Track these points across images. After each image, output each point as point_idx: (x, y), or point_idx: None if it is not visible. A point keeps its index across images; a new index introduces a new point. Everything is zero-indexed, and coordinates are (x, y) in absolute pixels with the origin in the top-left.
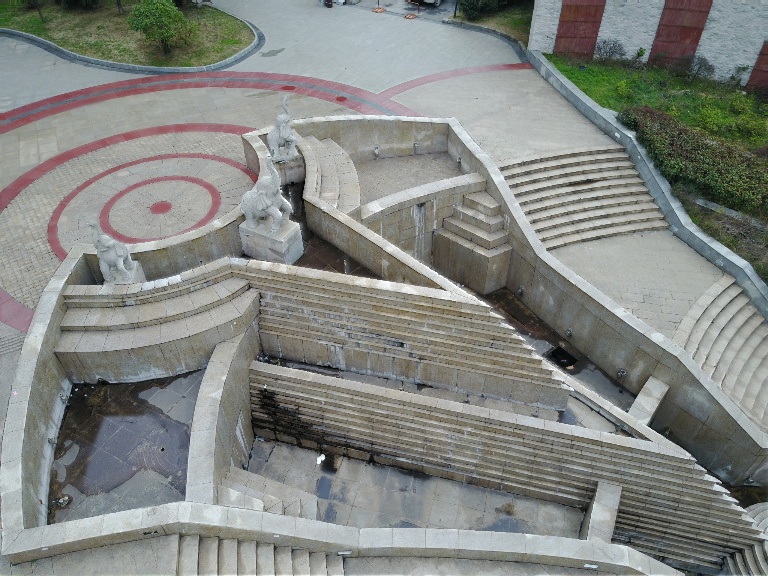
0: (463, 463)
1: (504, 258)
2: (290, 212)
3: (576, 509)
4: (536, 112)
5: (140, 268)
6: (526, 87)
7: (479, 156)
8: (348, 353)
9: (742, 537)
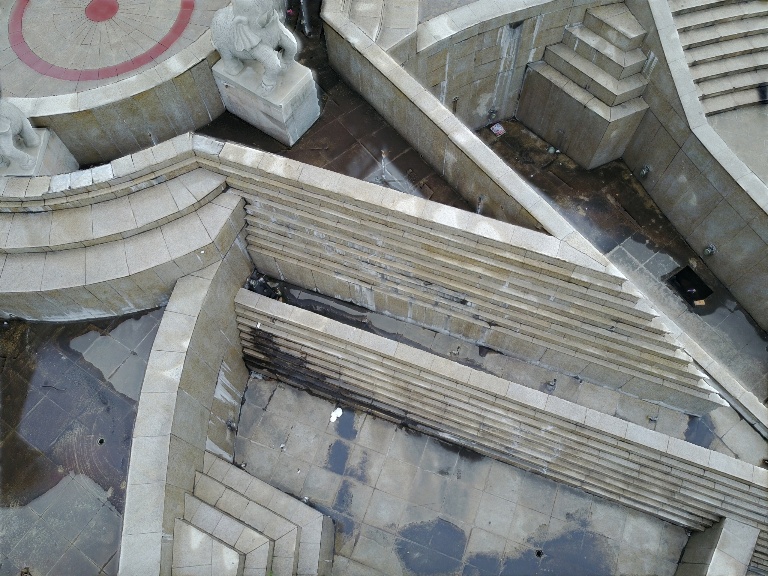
0: (531, 456)
1: (632, 121)
2: (295, 52)
3: (678, 528)
4: None
5: (54, 139)
6: None
7: None
8: (380, 296)
9: None
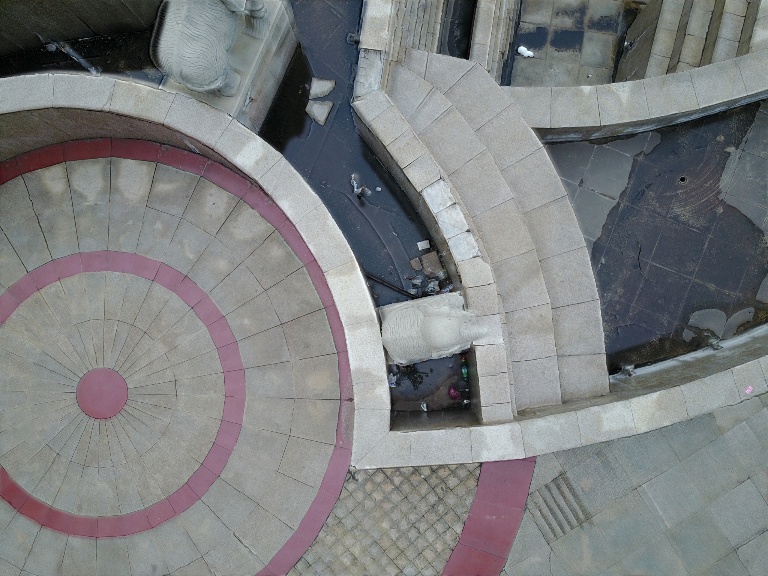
0: None
1: None
2: None
3: None
4: None
5: None
6: None
7: None
8: None
9: None
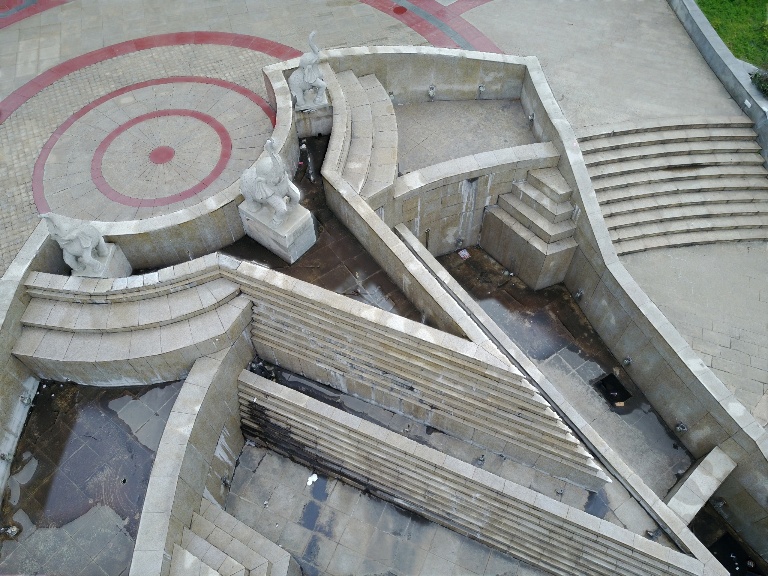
0: (467, 521)
1: (565, 255)
2: (298, 200)
3: None
4: (645, 54)
5: (118, 251)
6: (640, 12)
7: (556, 122)
8: (350, 381)
9: None
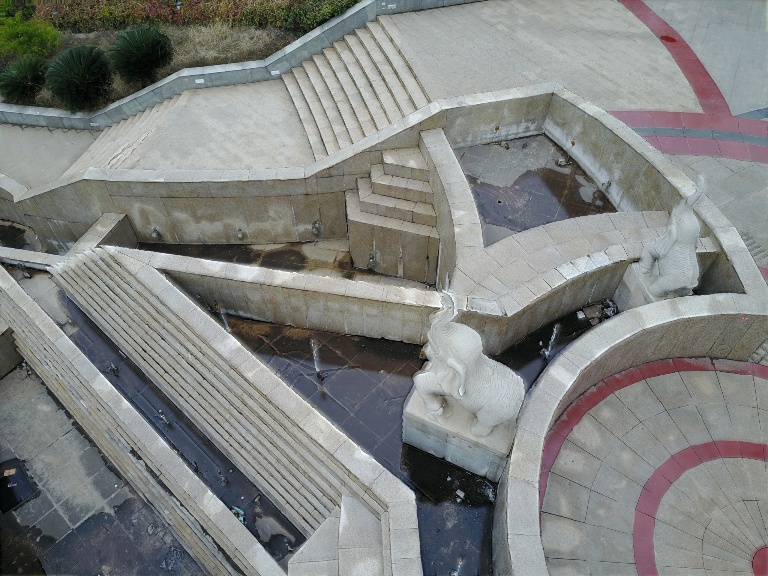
0: None
1: None
2: None
3: None
4: None
5: None
6: None
7: None
8: None
9: None
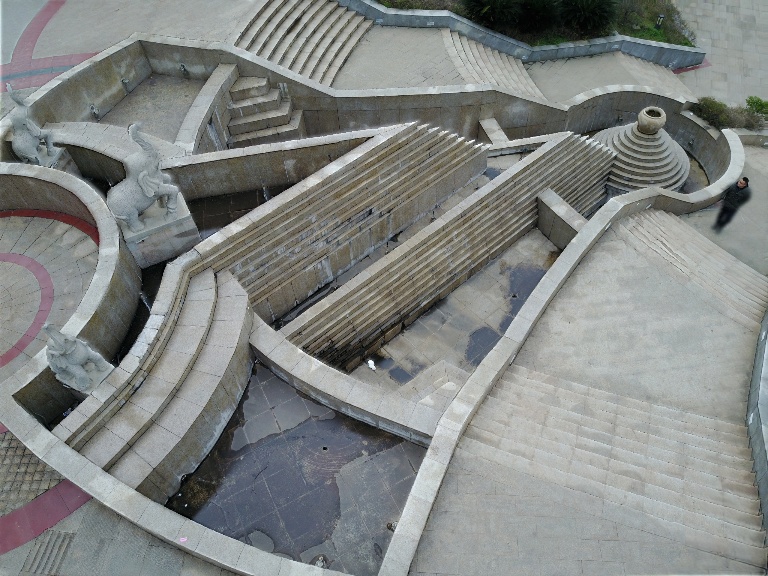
0: (462, 264)
1: (302, 123)
2: (168, 183)
3: (531, 231)
4: None
5: None
6: None
7: (211, 46)
8: (333, 259)
9: (606, 165)
